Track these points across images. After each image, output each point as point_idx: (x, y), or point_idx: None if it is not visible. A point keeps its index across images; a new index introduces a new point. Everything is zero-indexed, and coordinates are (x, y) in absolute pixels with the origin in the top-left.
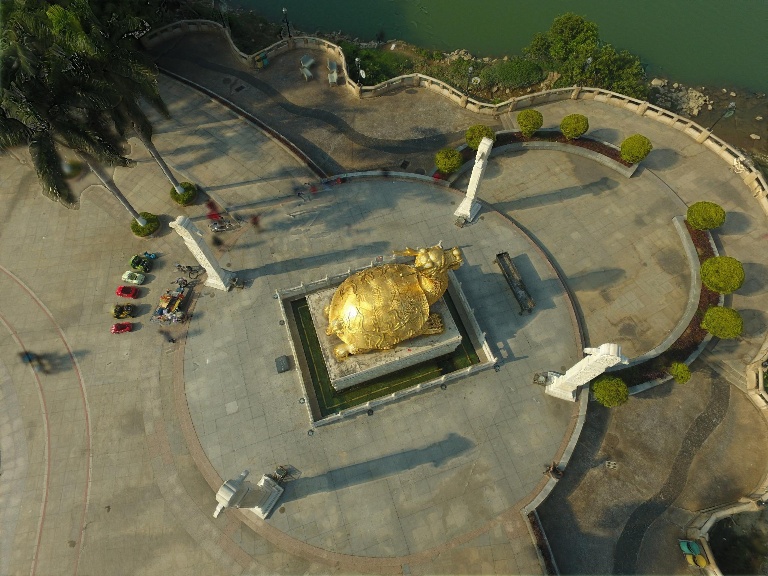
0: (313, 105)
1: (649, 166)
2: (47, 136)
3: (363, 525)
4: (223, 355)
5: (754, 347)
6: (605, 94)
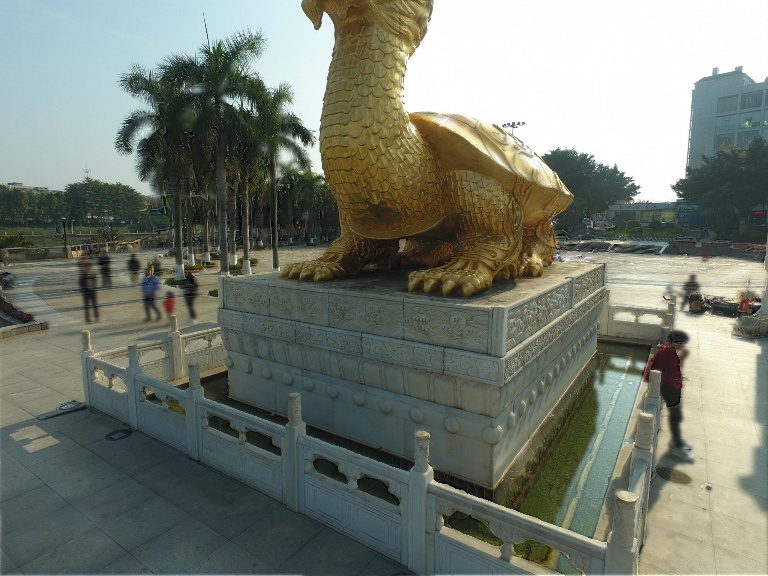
0: None
1: None
2: None
3: None
4: None
5: None
6: None
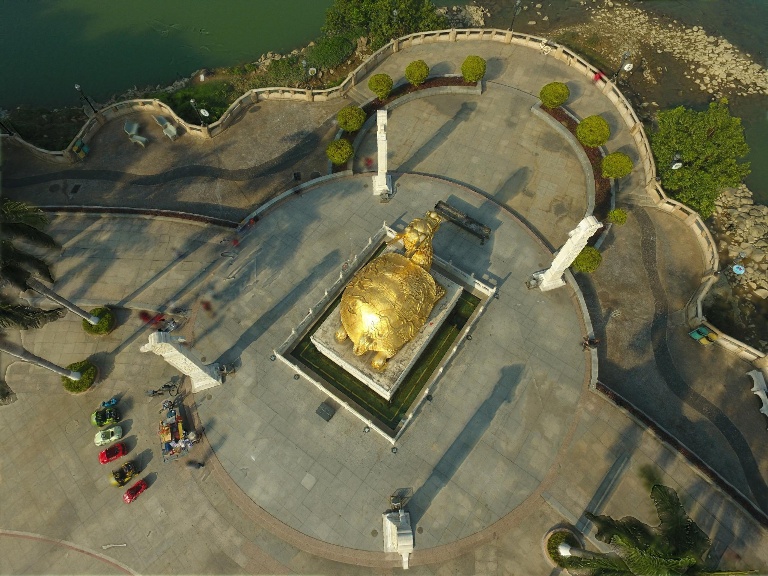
0: (168, 167)
1: (487, 78)
2: None
3: (491, 489)
4: (264, 443)
5: (640, 172)
6: (418, 36)
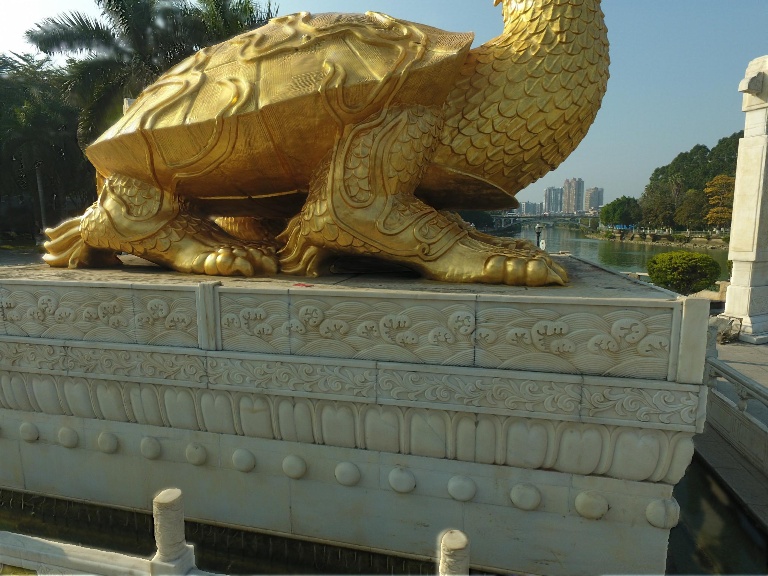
0: None
1: None
2: (121, 66)
3: None
4: None
5: None
6: None
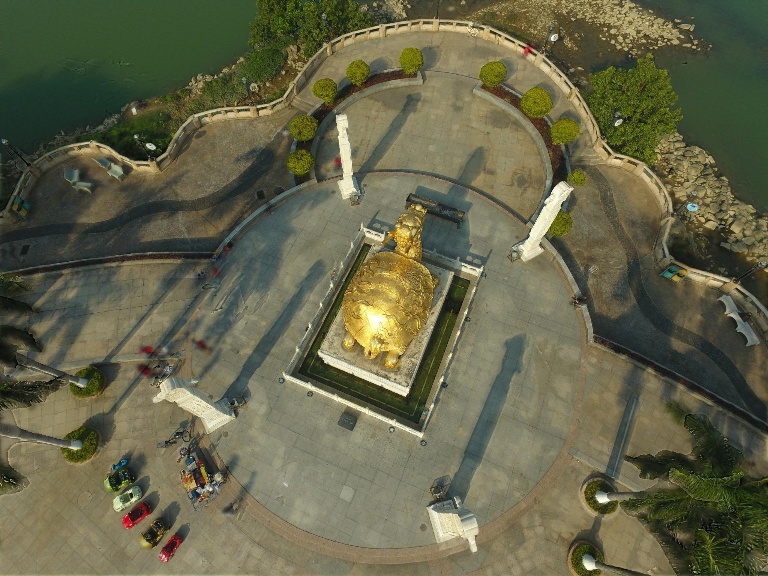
0: (122, 209)
1: (425, 68)
2: None
3: (522, 458)
4: (293, 466)
5: (585, 134)
6: (349, 37)
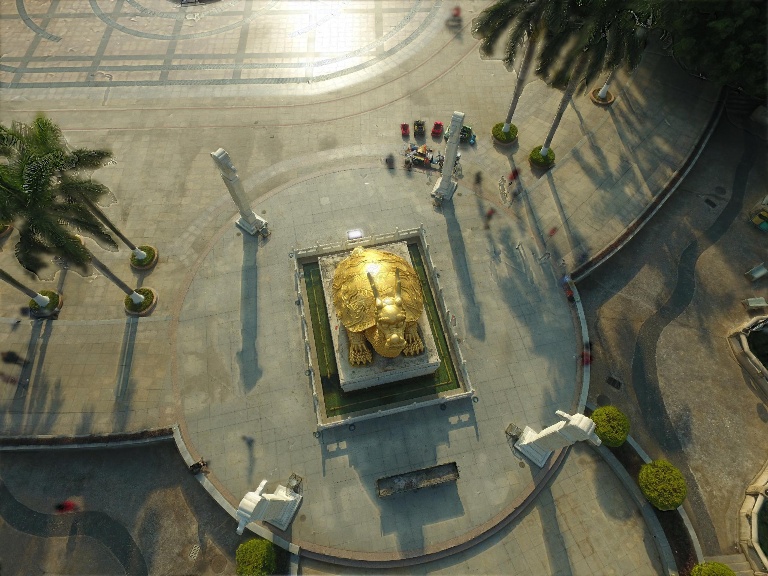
0: (701, 279)
1: None
2: (522, 4)
3: (210, 289)
4: (371, 193)
5: None
6: None
